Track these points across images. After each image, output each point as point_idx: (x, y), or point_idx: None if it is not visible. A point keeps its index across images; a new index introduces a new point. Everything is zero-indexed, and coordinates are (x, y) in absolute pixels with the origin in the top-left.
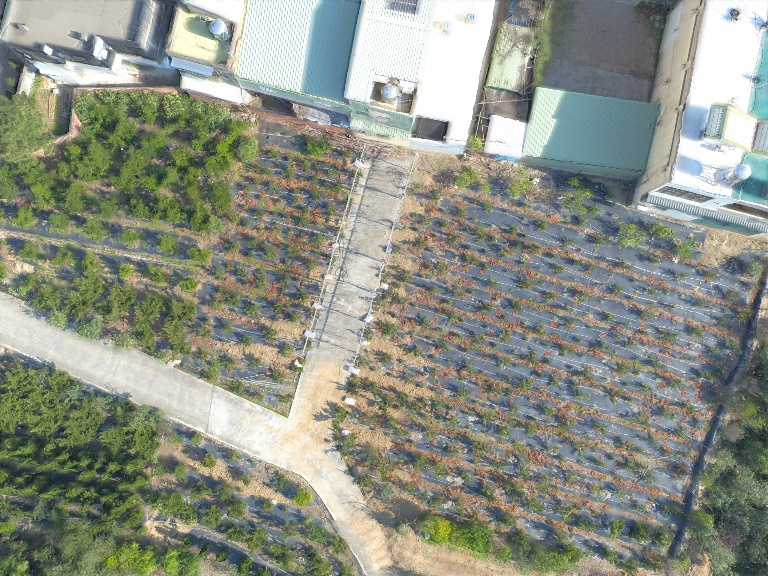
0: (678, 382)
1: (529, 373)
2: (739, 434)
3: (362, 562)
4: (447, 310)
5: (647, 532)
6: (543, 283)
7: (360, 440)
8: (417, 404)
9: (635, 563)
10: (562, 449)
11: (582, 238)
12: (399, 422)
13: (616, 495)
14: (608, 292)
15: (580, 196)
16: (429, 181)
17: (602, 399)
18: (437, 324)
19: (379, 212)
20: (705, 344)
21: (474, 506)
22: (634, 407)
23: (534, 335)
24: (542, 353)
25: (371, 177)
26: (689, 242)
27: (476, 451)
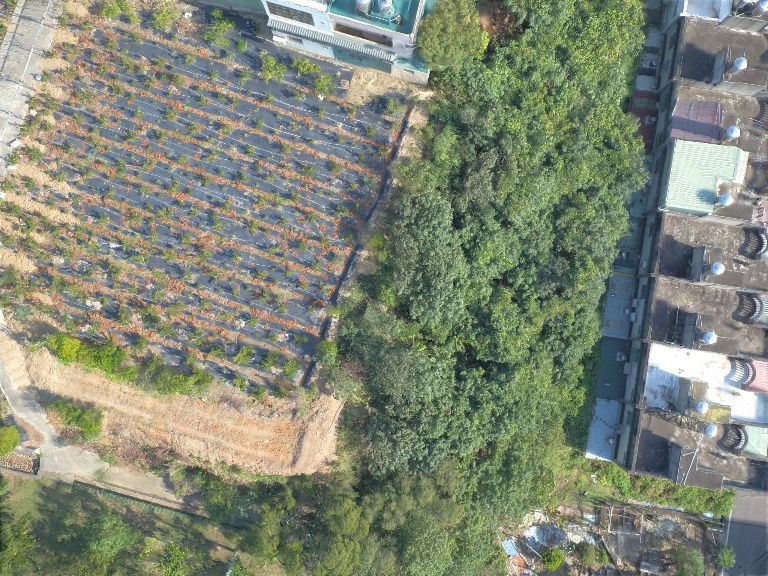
0: (311, 213)
1: (171, 203)
2: (376, 269)
3: (0, 381)
4: (95, 139)
5: (271, 357)
6: (189, 115)
7: (4, 263)
8: (57, 228)
9: (262, 389)
10: (199, 278)
11: (230, 72)
12: (42, 246)
13: (249, 324)
14: (253, 126)
15: (221, 27)
16: (84, 13)
17: (241, 230)
18: (83, 152)
19: (32, 41)
20: (346, 180)
21: (112, 330)
22: (272, 239)
23: (179, 166)
24: (185, 183)
25: (27, 7)
26: (336, 80)
27: (114, 276)
